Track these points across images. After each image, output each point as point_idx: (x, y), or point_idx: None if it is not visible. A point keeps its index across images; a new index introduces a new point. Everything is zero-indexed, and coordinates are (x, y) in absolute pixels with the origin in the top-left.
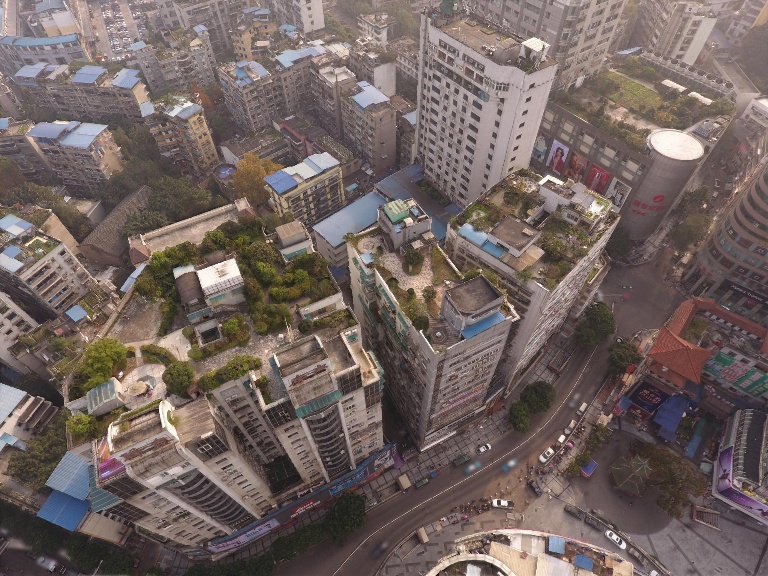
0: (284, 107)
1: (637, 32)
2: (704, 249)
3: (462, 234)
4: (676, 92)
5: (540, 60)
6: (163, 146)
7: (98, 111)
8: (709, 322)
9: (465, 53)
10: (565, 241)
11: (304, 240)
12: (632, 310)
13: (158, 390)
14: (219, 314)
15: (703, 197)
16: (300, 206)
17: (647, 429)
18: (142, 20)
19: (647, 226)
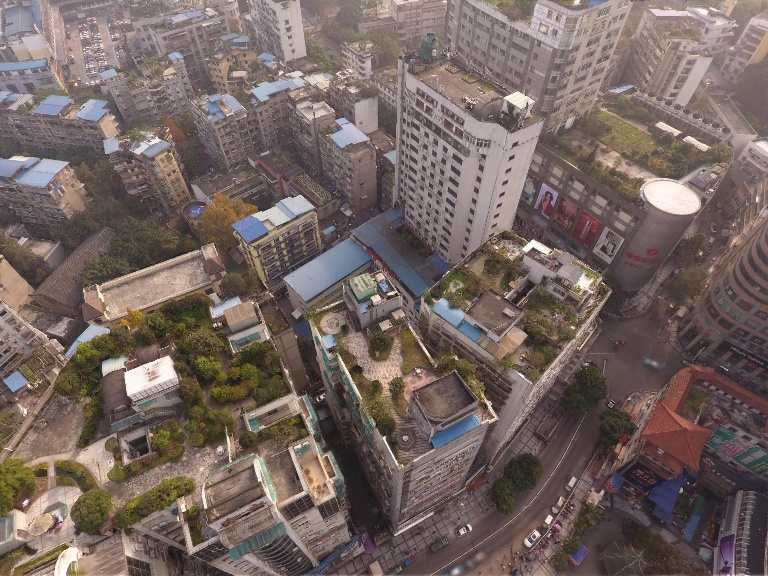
0: (260, 141)
1: (630, 66)
2: (701, 306)
3: (436, 312)
4: (671, 137)
5: (524, 118)
6: (130, 183)
7: (64, 143)
8: (708, 393)
9: (444, 105)
10: (551, 319)
11: (256, 324)
12: (625, 369)
13: (69, 522)
14: (150, 420)
15: (699, 245)
16: (271, 253)
17: (641, 507)
18: (120, 42)
19: (641, 278)
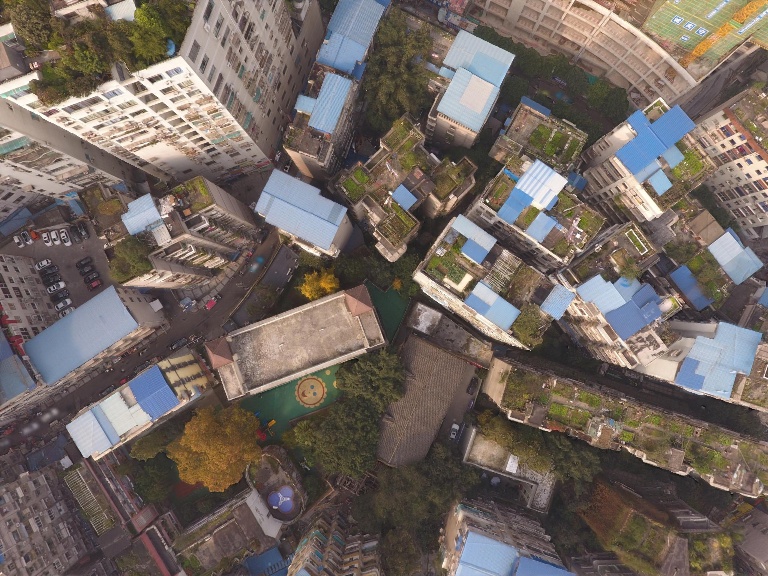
0: None
1: None
2: None
3: None
4: None
5: None
6: None
7: None
8: None
9: None
10: None
11: None
12: None
13: None
14: None
15: None
16: None
17: None
18: None
19: None
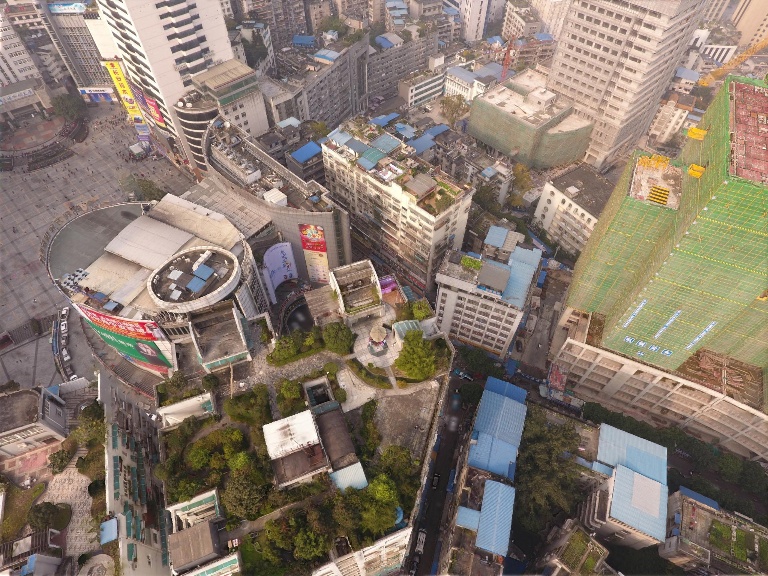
0: None
1: None
2: None
3: None
4: None
5: None
6: None
7: None
8: None
9: None
10: None
11: None
12: None
13: (365, 342)
14: None
15: None
16: None
17: None
18: None
19: None
